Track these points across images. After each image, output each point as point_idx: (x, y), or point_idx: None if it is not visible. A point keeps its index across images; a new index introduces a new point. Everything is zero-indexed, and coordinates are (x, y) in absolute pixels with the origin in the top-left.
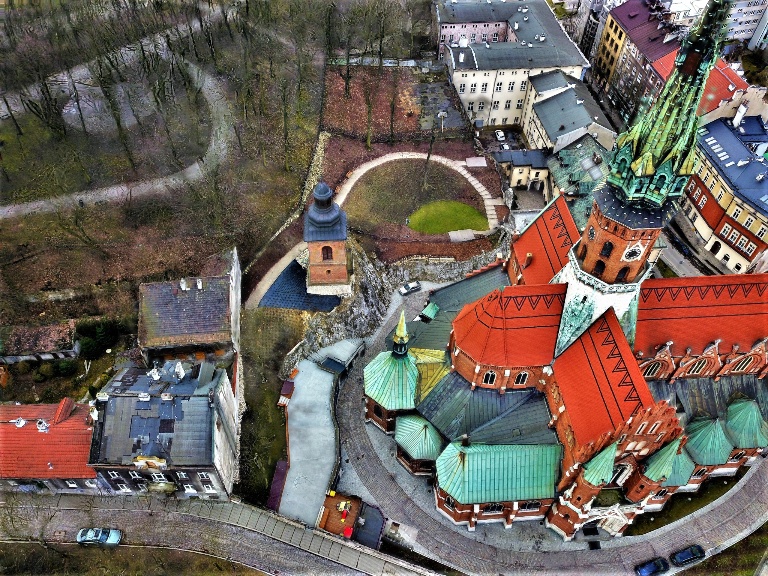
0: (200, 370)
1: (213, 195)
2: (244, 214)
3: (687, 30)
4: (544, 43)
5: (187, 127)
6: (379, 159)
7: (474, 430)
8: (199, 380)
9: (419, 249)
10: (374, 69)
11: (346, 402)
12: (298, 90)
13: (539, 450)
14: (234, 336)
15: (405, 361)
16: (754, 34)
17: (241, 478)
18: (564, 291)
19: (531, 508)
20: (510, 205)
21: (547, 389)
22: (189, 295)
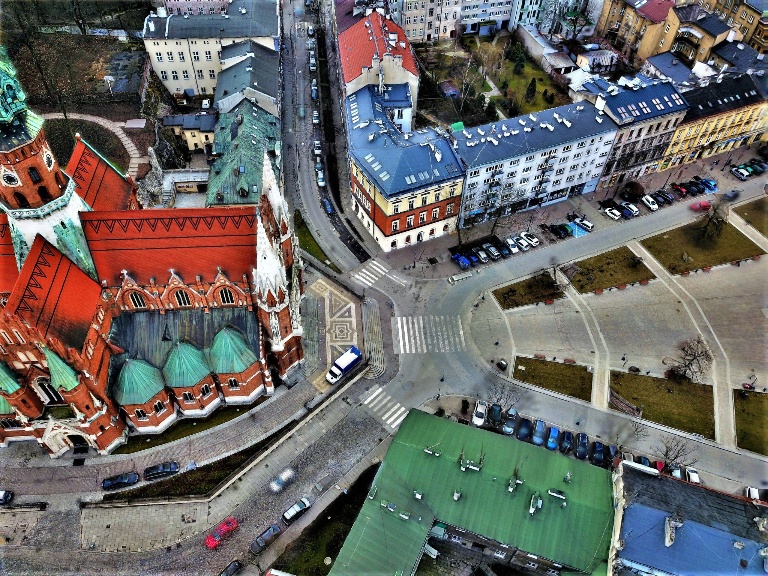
0: None
1: None
2: None
3: (376, 4)
4: (244, 15)
5: None
6: None
7: None
8: None
9: None
10: (82, 38)
11: None
12: None
13: None
14: None
15: None
16: (511, 16)
17: None
18: None
19: (15, 427)
20: (155, 163)
21: None
22: None
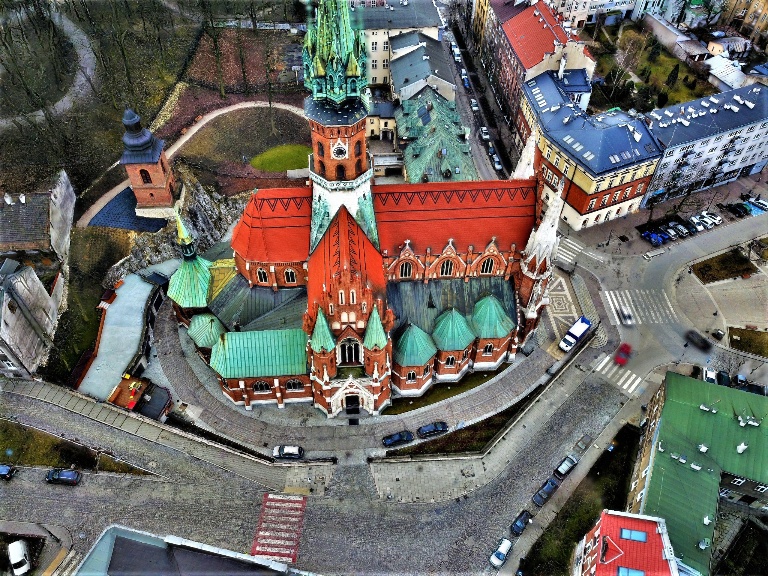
0: (3, 264)
1: (53, 128)
2: (86, 147)
3: None
4: (407, 7)
5: (46, 73)
6: (231, 107)
7: (250, 322)
8: (0, 271)
9: (257, 185)
10: (251, 31)
11: (166, 310)
12: (158, 44)
13: (290, 331)
14: (57, 246)
15: (194, 263)
16: (635, 5)
17: (49, 363)
18: (311, 194)
19: (297, 388)
20: None
21: None
22: (14, 209)
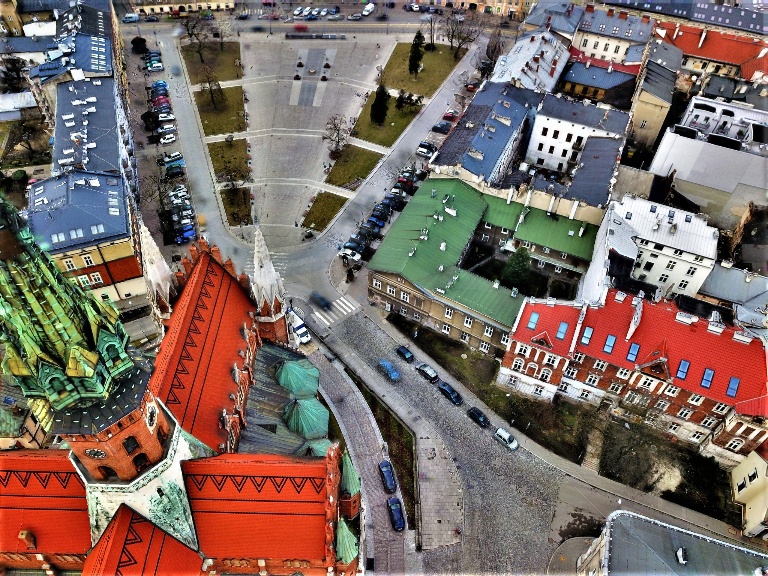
0: None
1: None
2: None
3: None
4: None
5: None
6: None
7: None
8: None
9: None
10: None
11: None
12: None
13: None
14: None
15: None
16: None
17: None
18: (130, 512)
19: None
20: None
21: (221, 570)
22: None
